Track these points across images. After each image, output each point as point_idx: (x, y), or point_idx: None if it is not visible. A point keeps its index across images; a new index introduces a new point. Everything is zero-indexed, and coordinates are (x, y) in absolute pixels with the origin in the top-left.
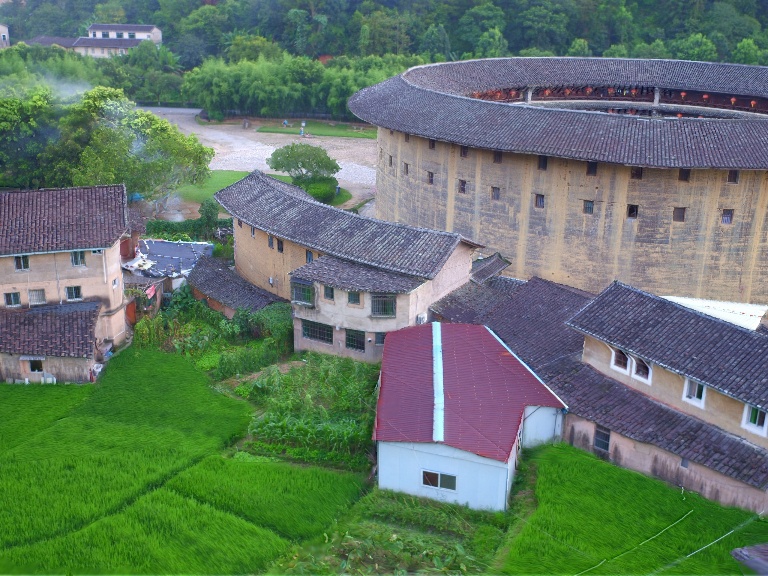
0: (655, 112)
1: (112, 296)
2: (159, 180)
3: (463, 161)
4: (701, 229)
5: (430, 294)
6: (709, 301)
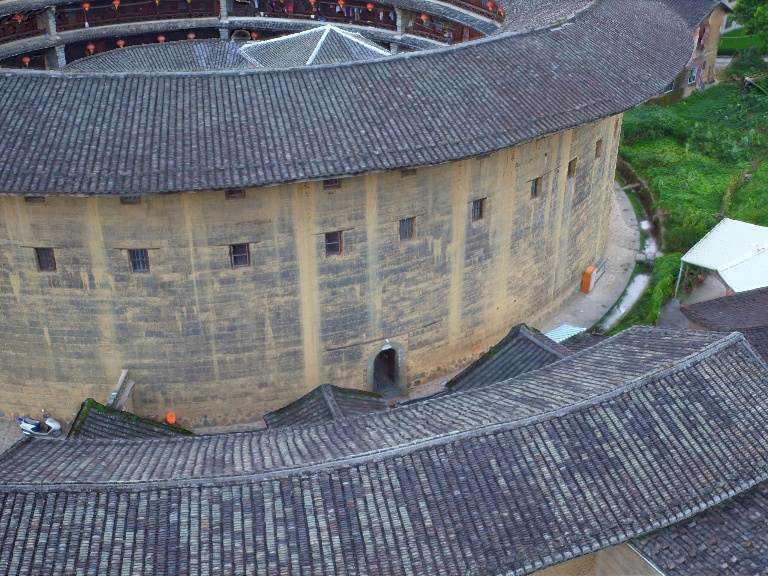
0: (54, 8)
1: None
2: None
3: (333, 196)
4: (606, 158)
5: None
6: (711, 243)
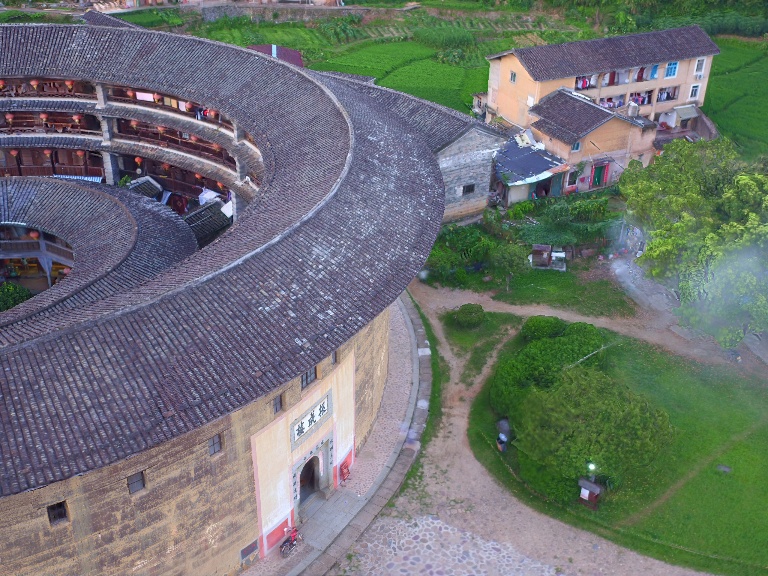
0: None
1: None
2: None
3: None
4: None
5: None
6: None
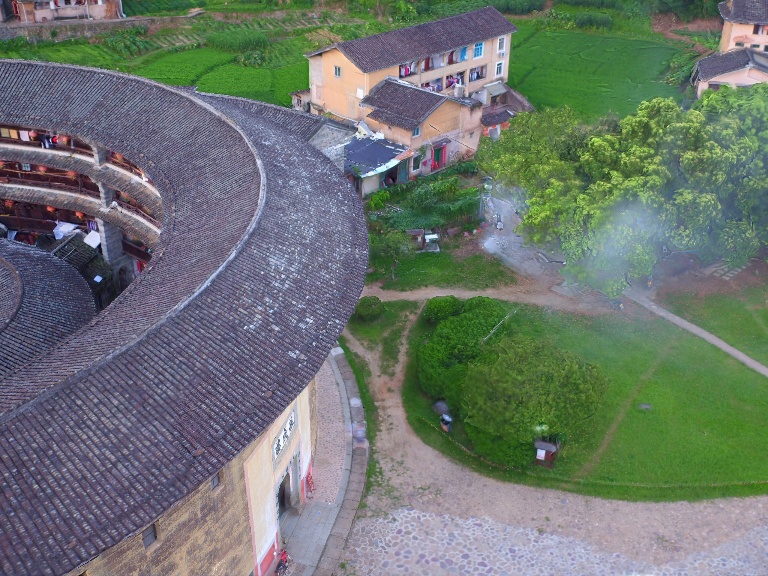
0: None
1: None
2: None
3: None
4: None
5: None
6: None
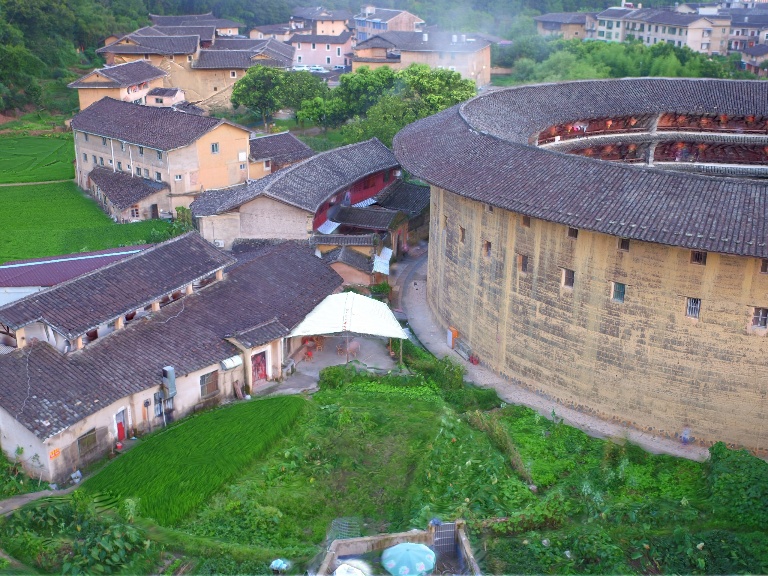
0: None
1: (174, 185)
2: (389, 141)
3: None
4: None
5: (238, 229)
6: (385, 315)
